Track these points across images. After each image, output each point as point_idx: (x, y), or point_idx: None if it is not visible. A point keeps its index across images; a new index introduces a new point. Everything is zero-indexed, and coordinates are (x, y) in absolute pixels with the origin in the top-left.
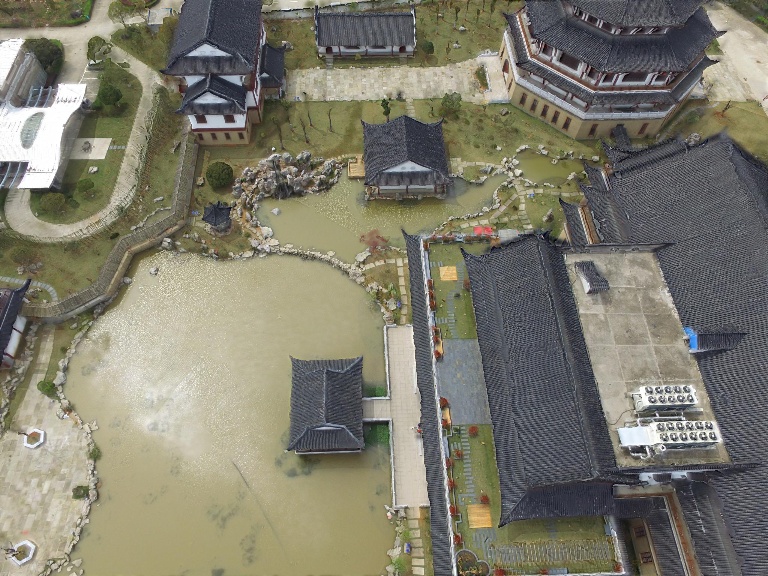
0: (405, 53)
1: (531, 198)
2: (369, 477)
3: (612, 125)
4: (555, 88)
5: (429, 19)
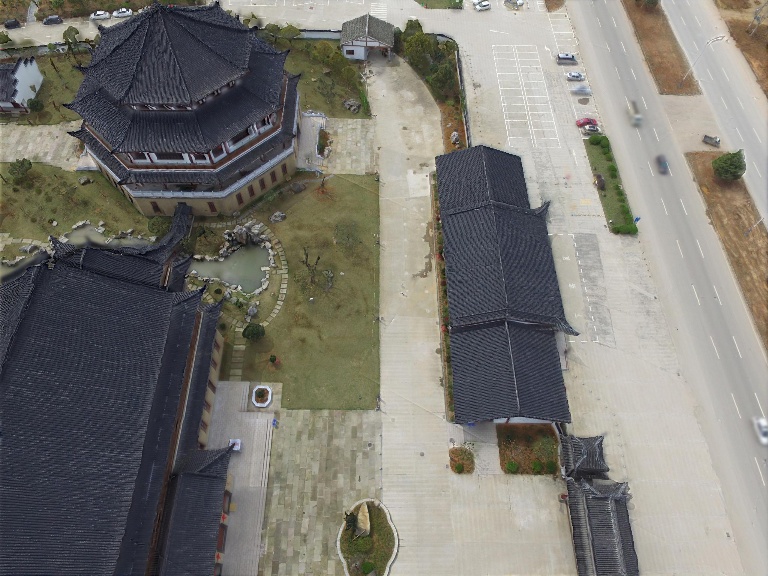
0: (20, 109)
1: None
2: None
3: (172, 203)
4: None
5: (69, 70)
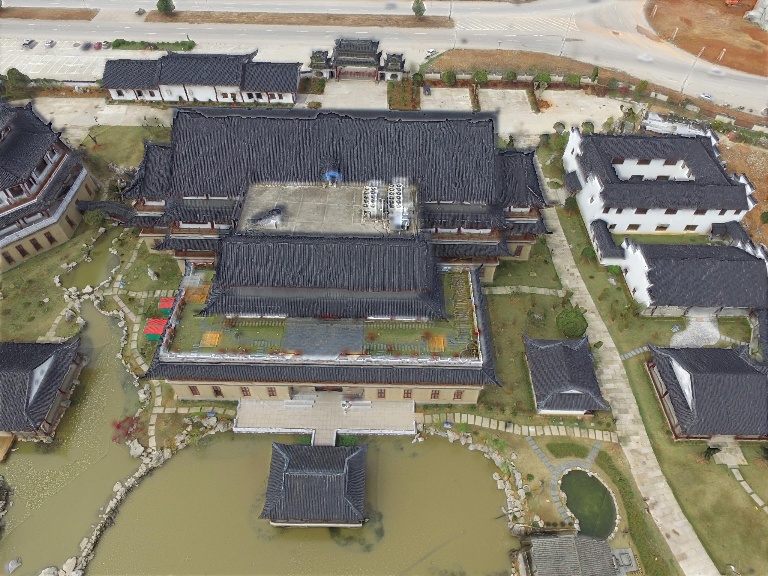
0: None
1: (125, 285)
2: (387, 455)
3: (73, 207)
4: (2, 232)
5: None
